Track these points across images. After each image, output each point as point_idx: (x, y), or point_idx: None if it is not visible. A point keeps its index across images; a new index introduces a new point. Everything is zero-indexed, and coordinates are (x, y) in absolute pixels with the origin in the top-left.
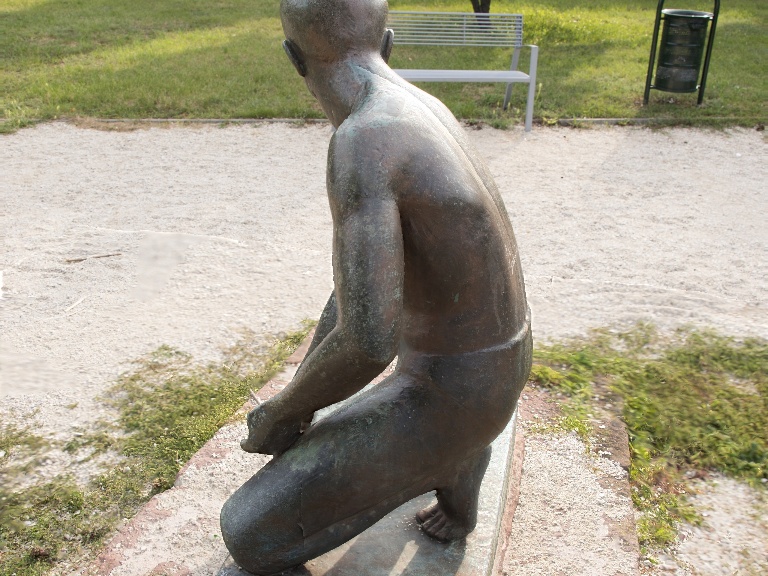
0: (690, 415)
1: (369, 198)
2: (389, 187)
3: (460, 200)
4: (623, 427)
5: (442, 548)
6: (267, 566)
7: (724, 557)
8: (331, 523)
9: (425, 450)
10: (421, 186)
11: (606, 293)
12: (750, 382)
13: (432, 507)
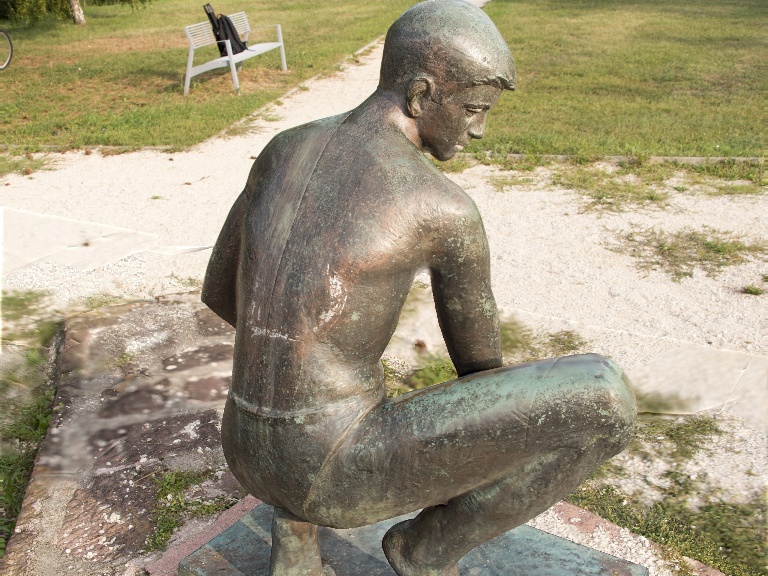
0: None
1: None
2: None
3: (243, 223)
4: None
5: None
6: None
7: None
8: None
9: None
10: None
11: None
12: None
13: None
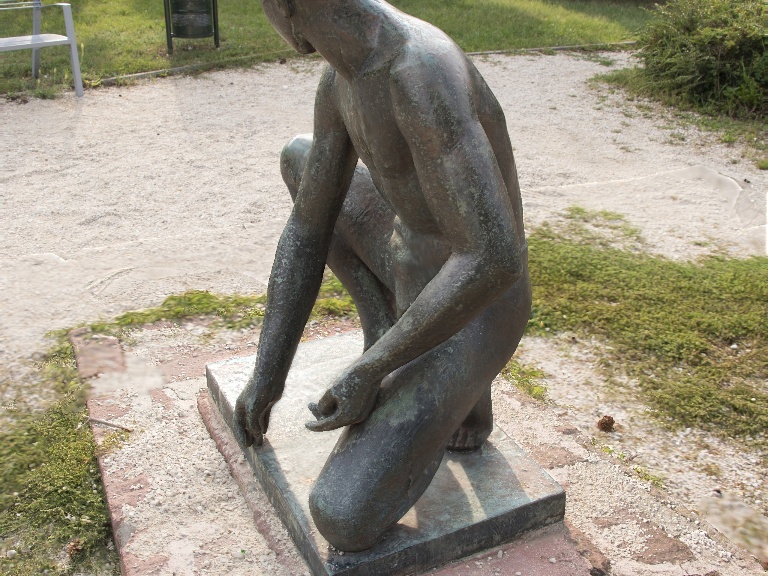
0: None
1: (469, 122)
2: (475, 108)
3: (502, 113)
4: None
5: (478, 455)
6: (380, 535)
7: (580, 391)
8: (427, 465)
9: (495, 360)
10: (483, 105)
11: None
12: None
13: None
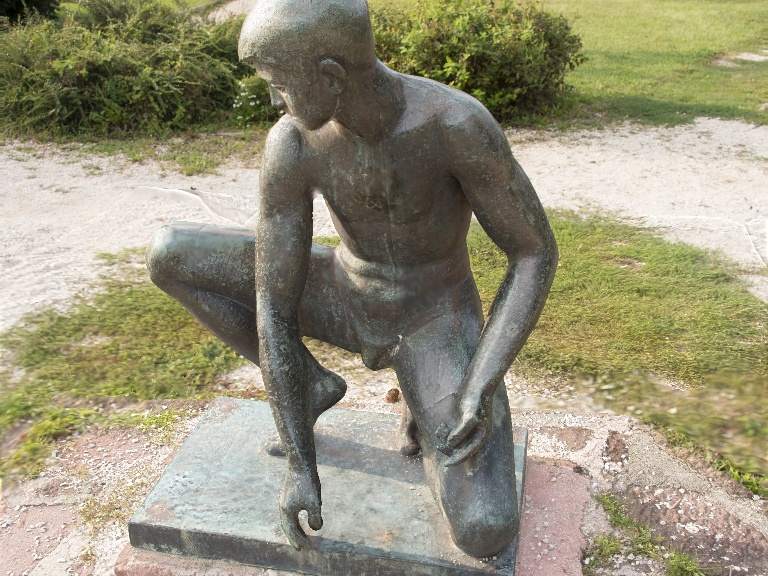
0: (140, 370)
1: None
2: None
3: None
4: (162, 399)
5: None
6: None
7: None
8: None
9: None
10: None
11: None
12: (91, 337)
13: (409, 437)
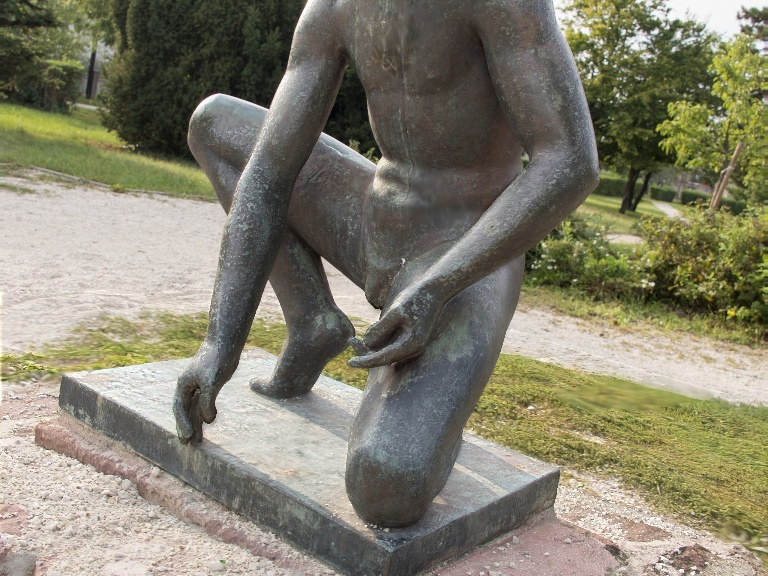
0: None
1: None
2: None
3: None
4: None
5: None
6: None
7: None
8: None
9: None
10: None
11: (34, 300)
12: None
13: None
